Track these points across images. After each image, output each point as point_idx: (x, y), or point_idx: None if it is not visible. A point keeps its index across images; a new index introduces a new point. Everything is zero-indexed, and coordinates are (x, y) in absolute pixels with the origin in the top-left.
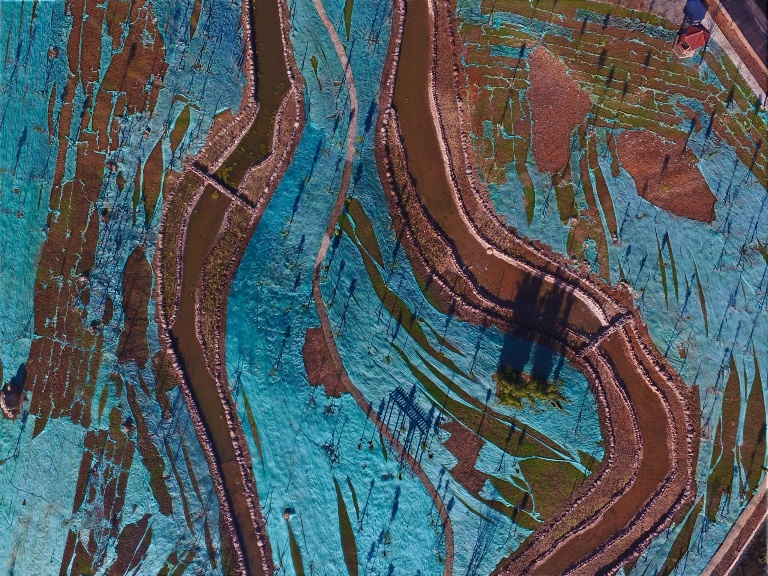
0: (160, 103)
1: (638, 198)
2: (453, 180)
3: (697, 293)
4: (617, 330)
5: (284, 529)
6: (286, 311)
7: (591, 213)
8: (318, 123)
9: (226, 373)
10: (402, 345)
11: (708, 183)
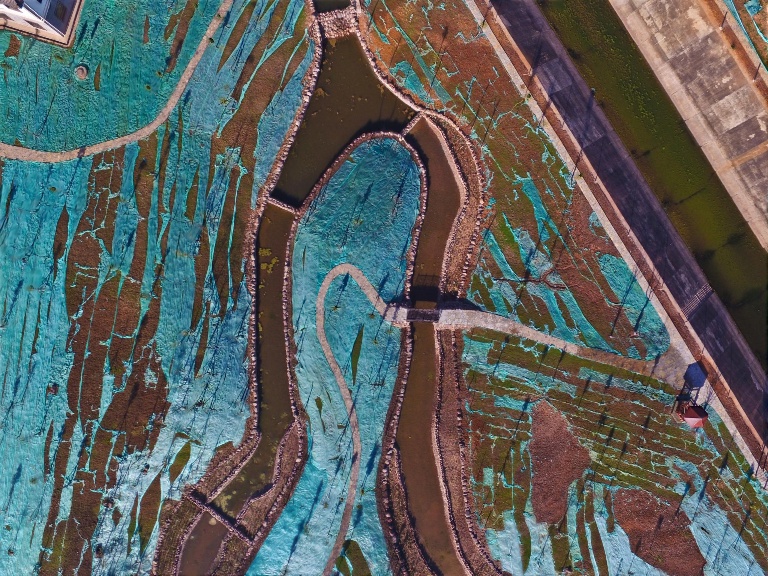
0: (160, 441)
1: (631, 554)
2: (452, 523)
3: None
4: None
5: None
6: None
7: (585, 566)
8: (320, 463)
9: None
10: None
11: (699, 545)
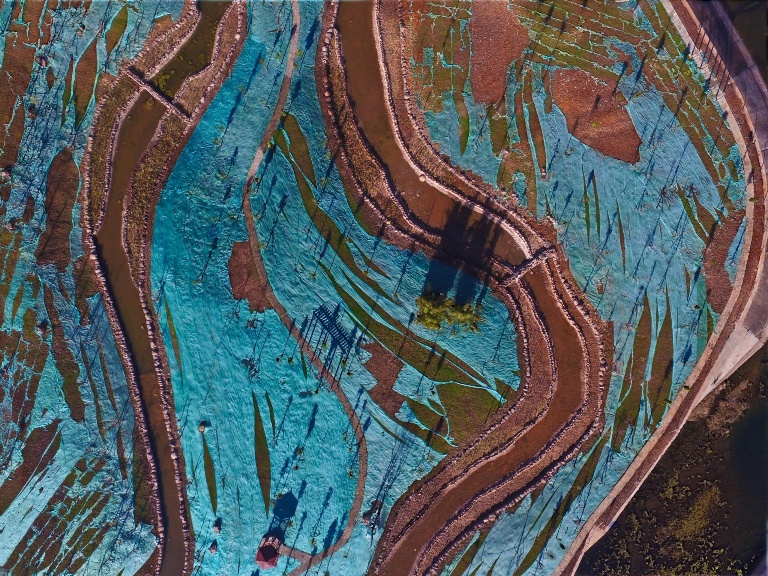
0: (96, 0)
1: (568, 135)
2: (391, 105)
3: (618, 231)
4: (540, 264)
5: (199, 442)
6: (214, 223)
7: (522, 147)
8: (259, 36)
9: (150, 283)
10: (329, 264)
11: (635, 125)
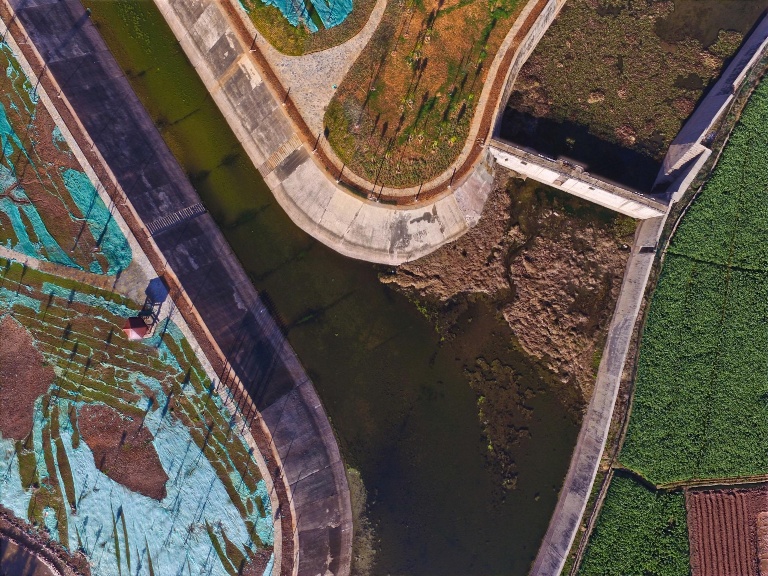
0: None
1: (96, 471)
2: None
3: (147, 567)
4: None
5: None
6: None
7: (51, 482)
8: None
9: None
10: None
11: (161, 461)
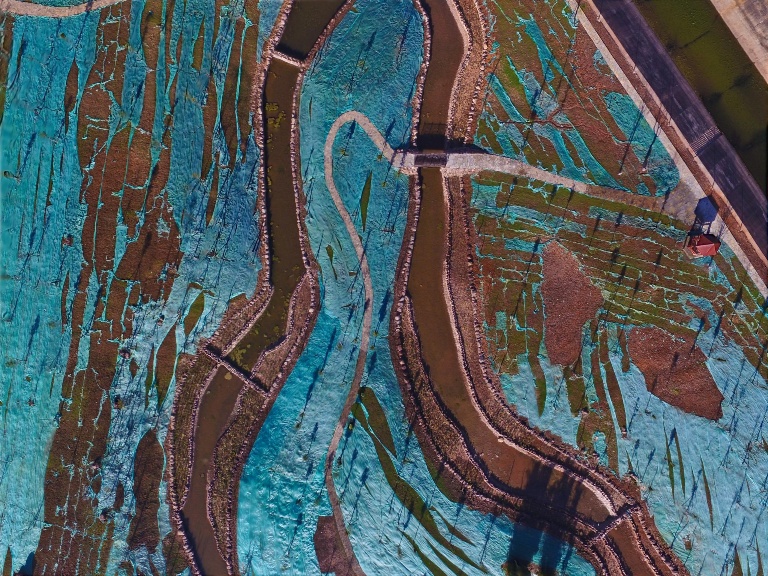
0: (175, 291)
1: (647, 393)
2: (466, 369)
3: (703, 488)
4: None
5: None
6: (298, 498)
7: (601, 407)
8: (333, 311)
9: (237, 556)
10: (413, 534)
11: (716, 381)
